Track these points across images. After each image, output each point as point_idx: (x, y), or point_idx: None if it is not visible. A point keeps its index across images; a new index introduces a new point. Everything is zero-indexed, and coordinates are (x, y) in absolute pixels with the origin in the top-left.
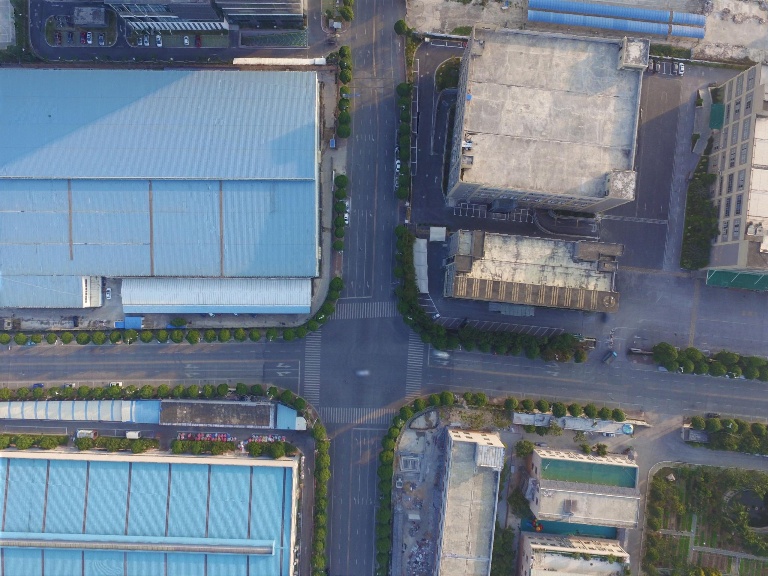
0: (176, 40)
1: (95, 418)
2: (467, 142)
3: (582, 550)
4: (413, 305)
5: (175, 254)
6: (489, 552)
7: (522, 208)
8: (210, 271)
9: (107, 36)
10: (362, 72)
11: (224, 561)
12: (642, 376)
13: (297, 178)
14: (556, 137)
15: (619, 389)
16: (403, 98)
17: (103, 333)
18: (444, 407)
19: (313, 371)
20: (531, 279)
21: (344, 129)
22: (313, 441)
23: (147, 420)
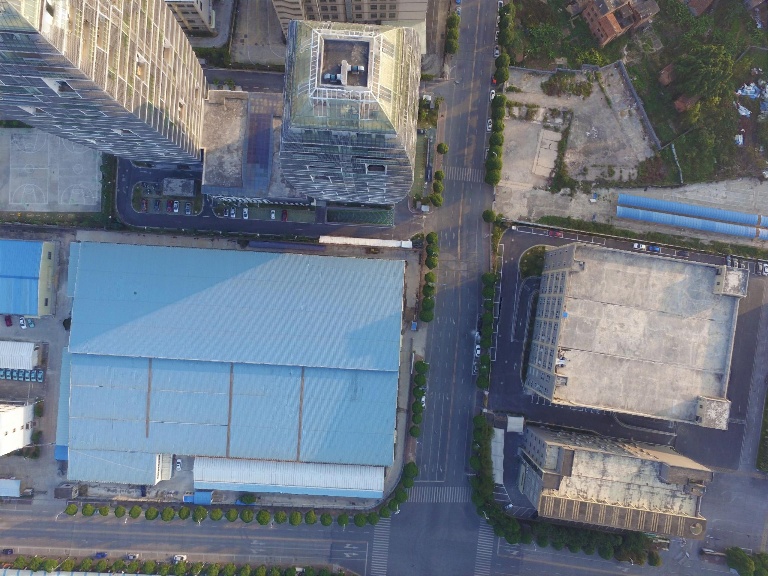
0: (262, 213)
1: None
2: (560, 359)
3: None
4: (489, 501)
5: (252, 437)
6: None
7: None
8: (286, 455)
9: (194, 205)
10: (446, 254)
11: None
12: None
13: (381, 370)
14: (649, 357)
15: None
16: (489, 290)
17: (172, 509)
18: None
19: (381, 554)
20: (616, 496)
21: (428, 317)
22: None
23: None
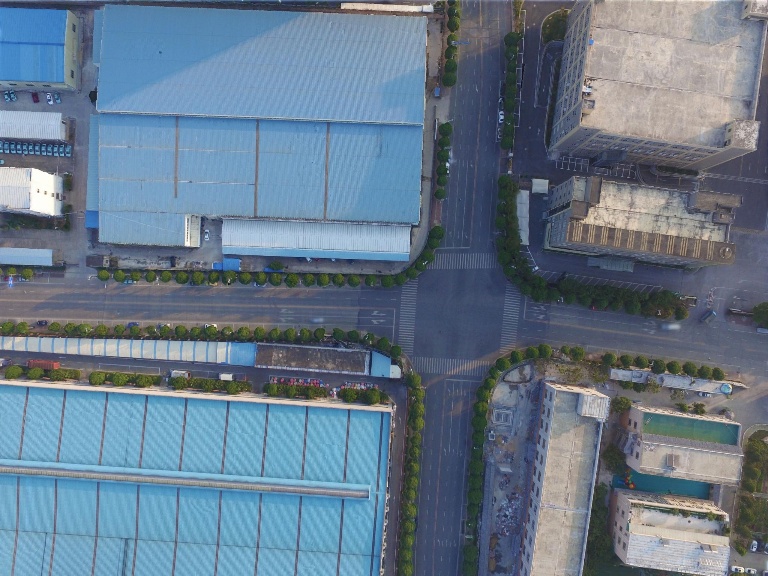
0: None
1: (190, 358)
2: (587, 87)
3: (680, 507)
4: (516, 255)
5: (279, 195)
6: (588, 504)
7: (625, 163)
8: (313, 214)
9: None
10: (468, 22)
11: (319, 504)
12: (740, 337)
13: (406, 122)
14: (676, 85)
15: (716, 349)
16: (512, 47)
17: (202, 273)
18: (541, 360)
19: (408, 320)
20: (644, 229)
21: (451, 76)
22: (405, 391)
23: (242, 362)
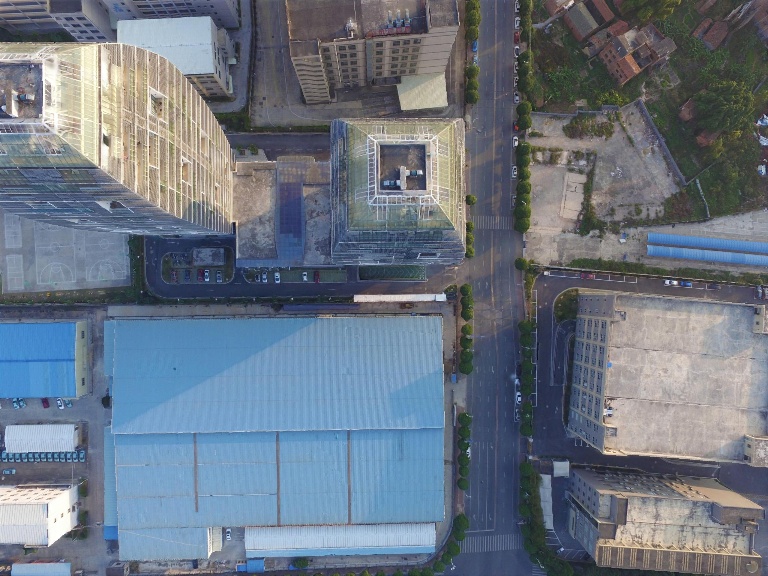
0: (294, 275)
1: None
2: (607, 408)
3: None
4: (542, 548)
5: (302, 503)
6: None
7: None
8: (337, 519)
9: (224, 273)
10: (481, 304)
11: None
12: None
13: None
14: (694, 400)
15: None
16: (527, 338)
17: None
18: None
19: None
20: (671, 539)
21: (468, 370)
22: None
23: None
